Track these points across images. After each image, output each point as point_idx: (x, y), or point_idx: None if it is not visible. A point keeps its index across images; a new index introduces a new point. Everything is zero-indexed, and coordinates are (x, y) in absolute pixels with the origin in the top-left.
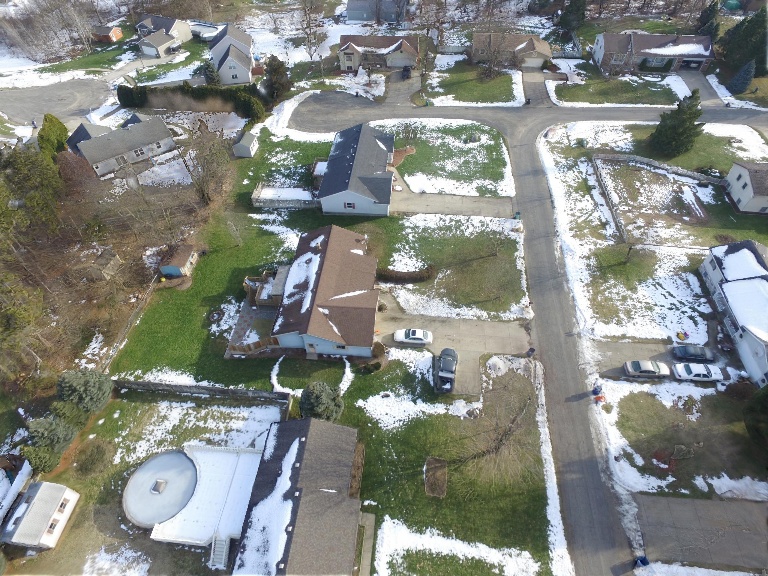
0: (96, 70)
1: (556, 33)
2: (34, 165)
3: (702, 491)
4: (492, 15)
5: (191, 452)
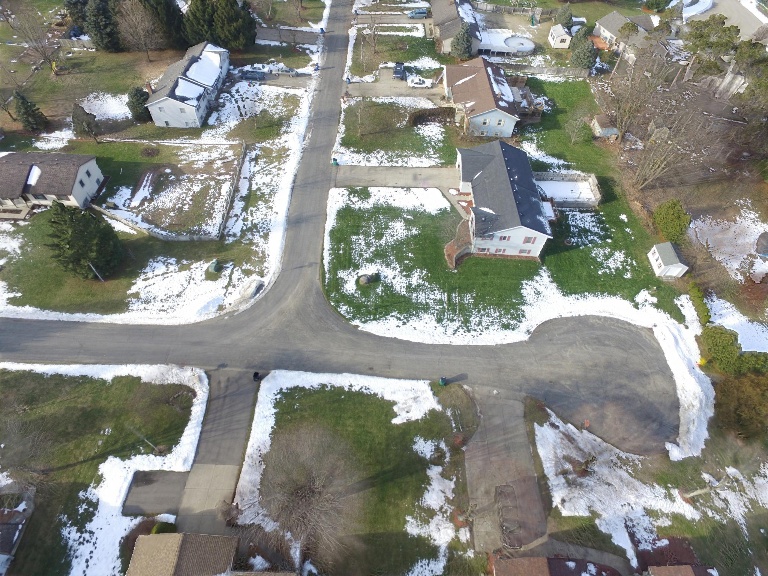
0: None
1: None
2: None
3: (286, 43)
4: None
5: None
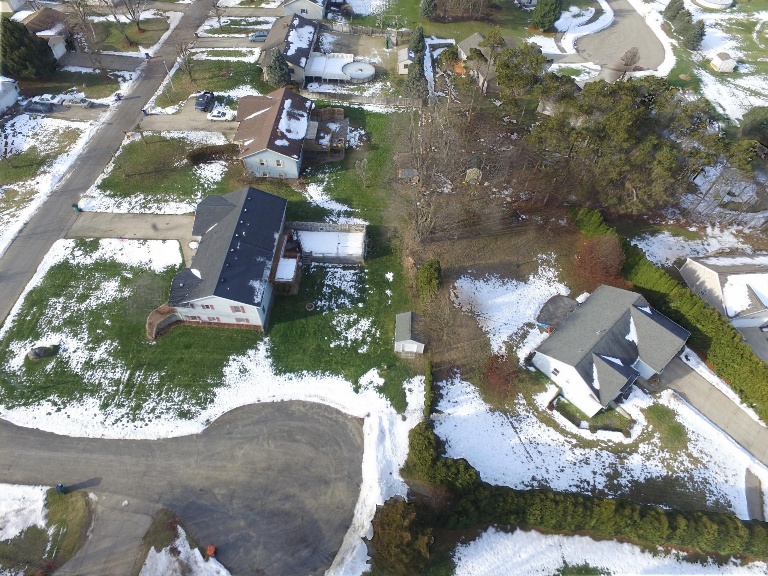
0: None
1: None
2: None
3: None
4: None
5: None
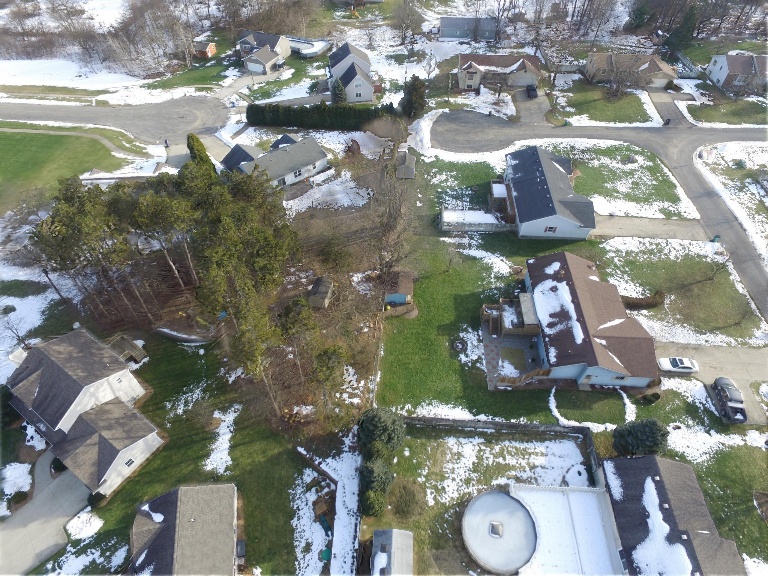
0: (205, 87)
1: (660, 53)
2: (265, 192)
3: None
4: (587, 34)
5: (514, 492)
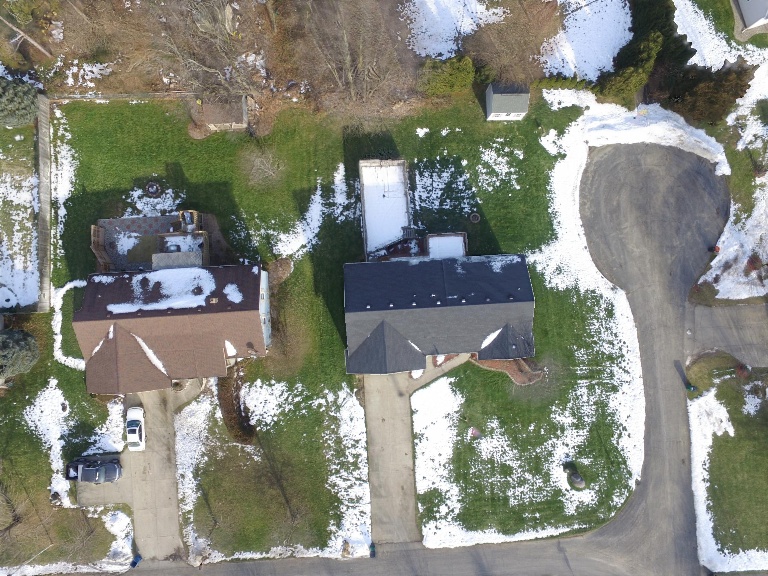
0: None
1: None
2: None
3: None
4: None
5: None
